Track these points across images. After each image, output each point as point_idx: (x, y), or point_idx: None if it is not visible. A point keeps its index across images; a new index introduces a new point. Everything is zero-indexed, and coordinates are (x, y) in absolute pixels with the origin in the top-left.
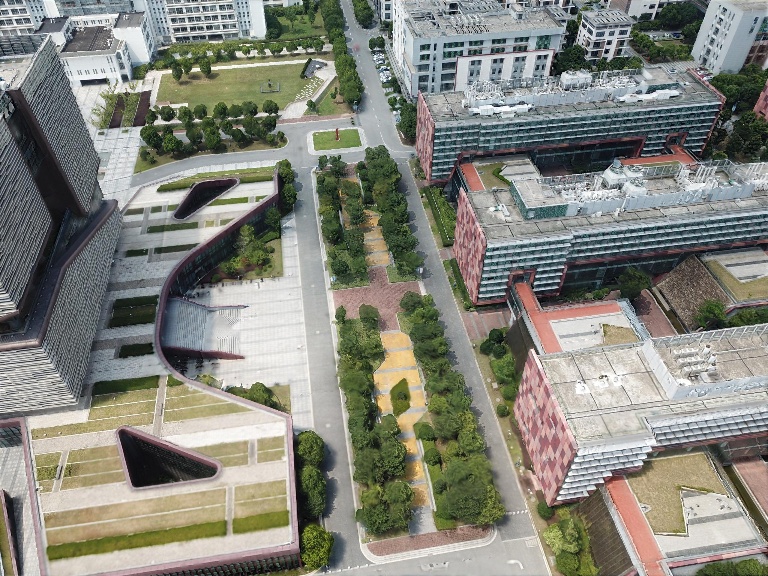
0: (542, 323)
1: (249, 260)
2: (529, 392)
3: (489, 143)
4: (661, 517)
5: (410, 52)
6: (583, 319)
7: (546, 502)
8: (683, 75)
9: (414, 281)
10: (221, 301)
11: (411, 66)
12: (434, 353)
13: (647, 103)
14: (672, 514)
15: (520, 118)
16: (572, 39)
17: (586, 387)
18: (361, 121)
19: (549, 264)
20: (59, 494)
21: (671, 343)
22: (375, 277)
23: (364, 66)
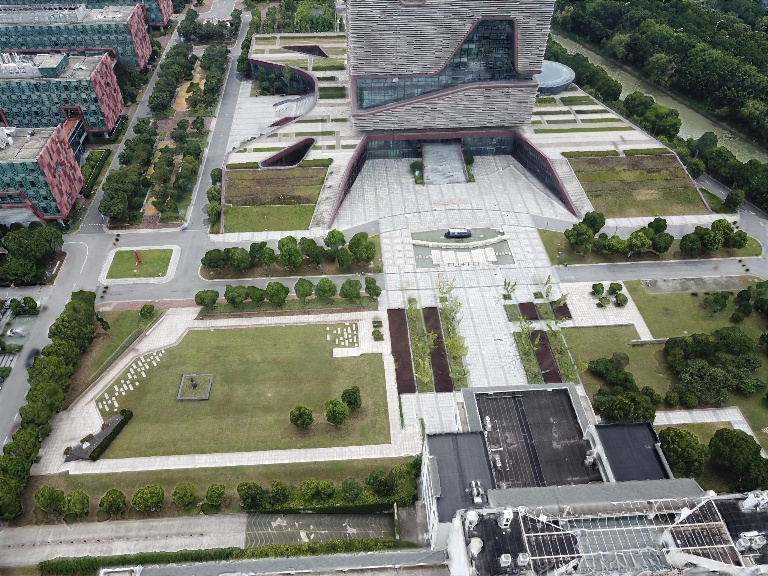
0: None
1: None
2: None
3: None
4: None
5: None
6: None
7: None
8: None
9: None
10: None
11: None
12: None
13: None
14: None
15: None
16: None
17: None
18: None
19: None
20: None
21: None
22: None
23: None
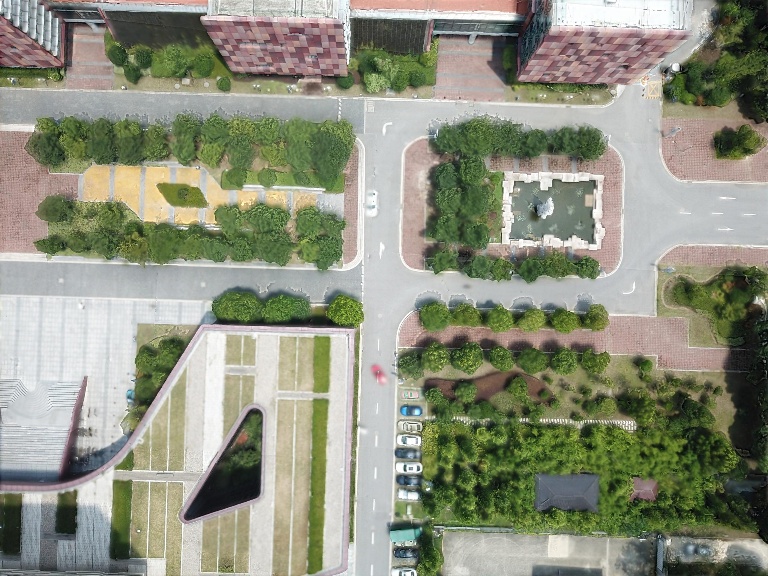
0: None
1: None
2: (239, 45)
3: None
4: None
5: None
6: None
7: (342, 77)
8: None
9: None
10: None
11: None
12: (137, 140)
13: None
14: None
15: None
16: None
17: None
18: None
19: None
20: (252, 574)
21: None
22: None
23: None
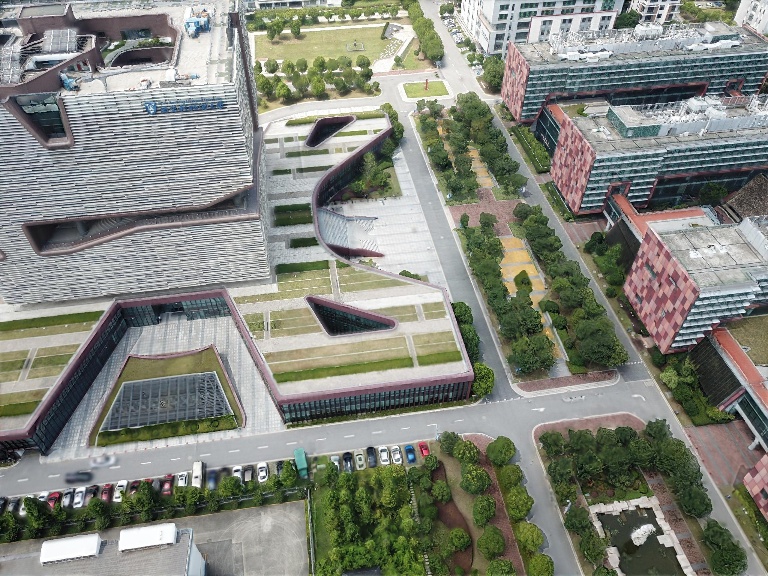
0: (640, 223)
1: (372, 183)
2: (645, 265)
3: (574, 85)
4: (759, 354)
5: (489, 12)
6: (674, 220)
7: (660, 351)
8: (740, 29)
9: (517, 199)
10: (354, 214)
11: (488, 26)
12: (550, 247)
13: (712, 51)
14: (767, 352)
15: (603, 63)
16: (625, 6)
17: (698, 253)
18: (444, 75)
19: (643, 177)
20: (270, 341)
21: (762, 223)
22: (483, 196)
23: (437, 29)
